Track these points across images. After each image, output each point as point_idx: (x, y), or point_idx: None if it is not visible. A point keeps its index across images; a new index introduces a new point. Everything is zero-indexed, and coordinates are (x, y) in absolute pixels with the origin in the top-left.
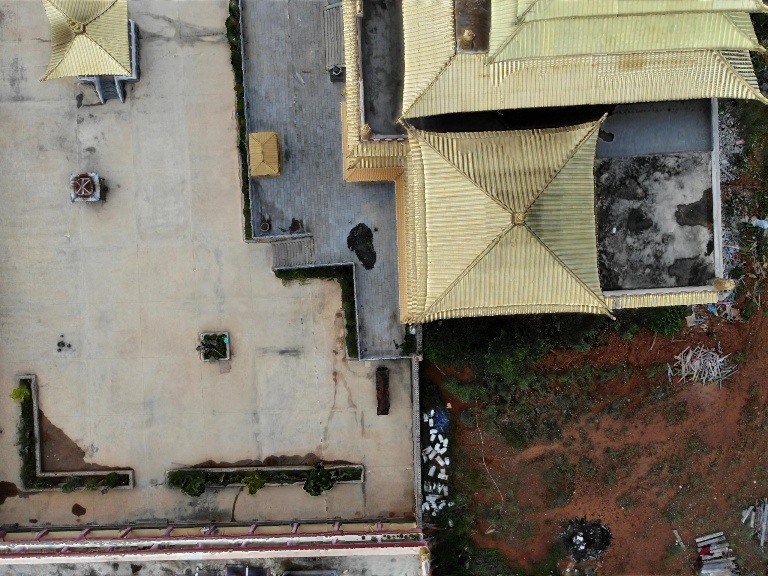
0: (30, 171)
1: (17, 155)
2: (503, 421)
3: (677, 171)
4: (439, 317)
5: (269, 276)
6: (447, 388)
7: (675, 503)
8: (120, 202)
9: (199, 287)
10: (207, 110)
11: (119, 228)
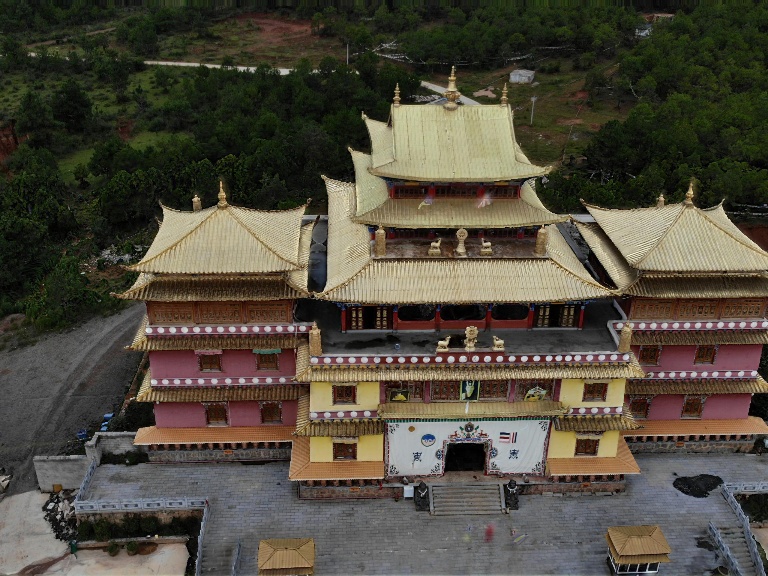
0: None
1: None
2: None
3: None
4: None
5: None
6: None
7: None
8: None
9: None
10: None
11: None
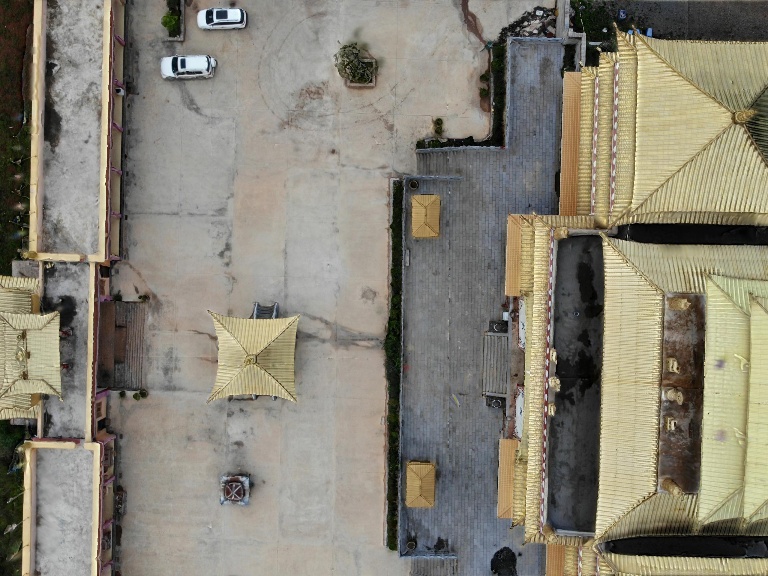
0: (177, 460)
1: (165, 443)
2: None
3: None
4: None
5: None
6: None
7: None
8: (264, 497)
9: None
10: (357, 413)
11: (261, 523)
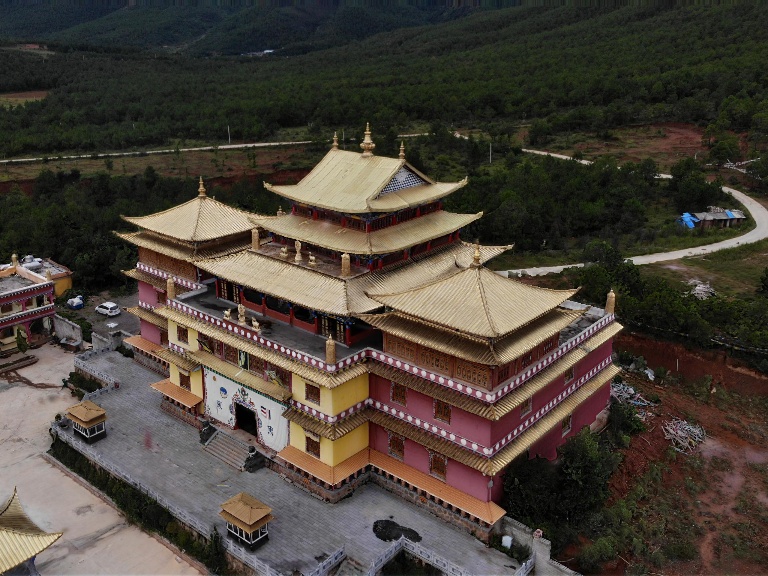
0: None
1: None
2: (656, 551)
3: None
4: (507, 359)
5: None
6: (589, 560)
7: None
8: None
9: None
10: (148, 573)
11: None
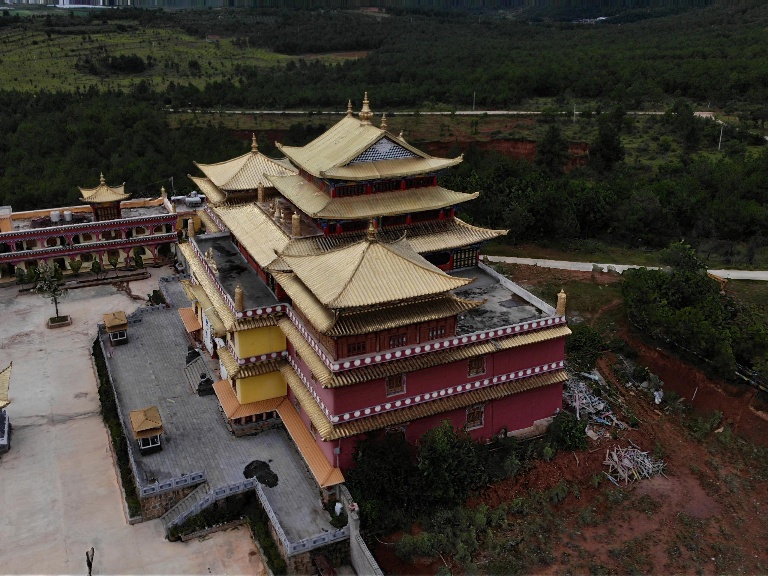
0: None
1: None
2: (482, 563)
3: (484, 292)
4: (343, 332)
5: (162, 544)
6: (401, 548)
7: (723, 574)
8: None
9: (74, 575)
10: (80, 453)
11: None
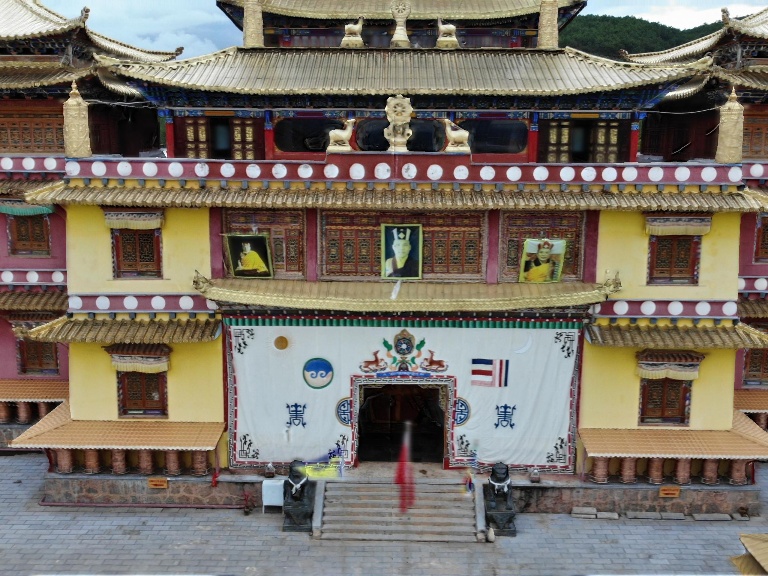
0: None
1: None
2: None
3: None
4: None
5: None
6: None
7: None
8: None
9: None
10: None
11: None
